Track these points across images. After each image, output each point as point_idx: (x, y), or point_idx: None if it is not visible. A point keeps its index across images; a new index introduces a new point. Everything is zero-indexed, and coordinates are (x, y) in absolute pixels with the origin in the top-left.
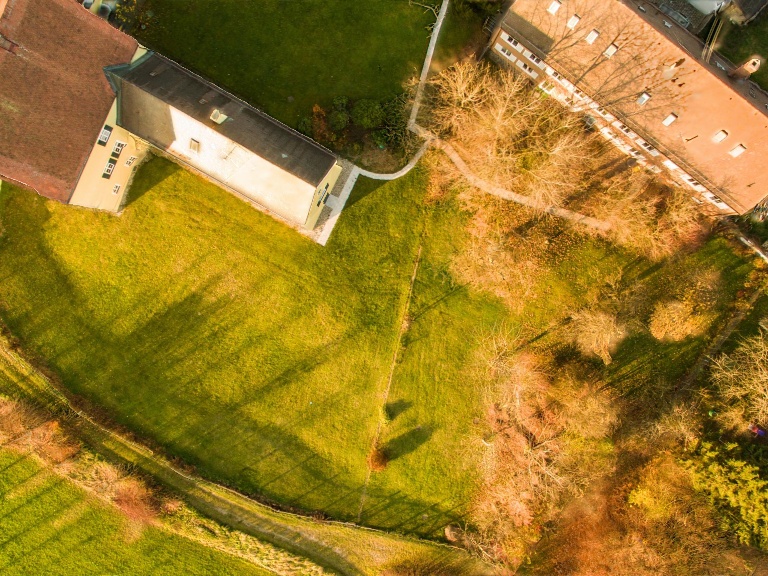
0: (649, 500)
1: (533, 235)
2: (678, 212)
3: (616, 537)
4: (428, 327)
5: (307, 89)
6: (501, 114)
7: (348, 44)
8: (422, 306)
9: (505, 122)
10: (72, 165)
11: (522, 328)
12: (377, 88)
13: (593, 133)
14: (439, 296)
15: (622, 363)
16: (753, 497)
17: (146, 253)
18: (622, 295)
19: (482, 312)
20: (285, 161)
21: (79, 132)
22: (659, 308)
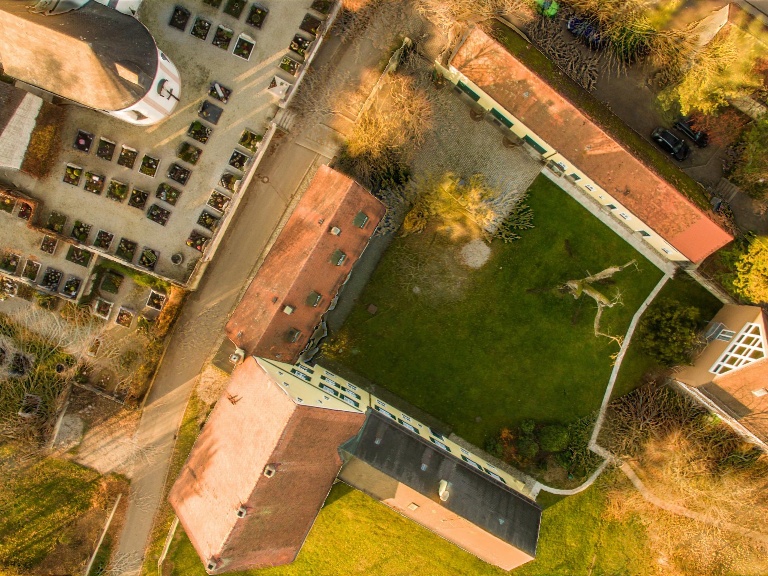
0: None
1: (701, 547)
2: None
3: None
4: None
5: (495, 411)
6: (676, 436)
7: (536, 370)
8: None
9: None
10: (301, 532)
11: None
12: (561, 411)
13: None
14: None
15: None
16: None
17: (329, 553)
18: None
19: None
20: (504, 529)
21: (311, 504)
22: None
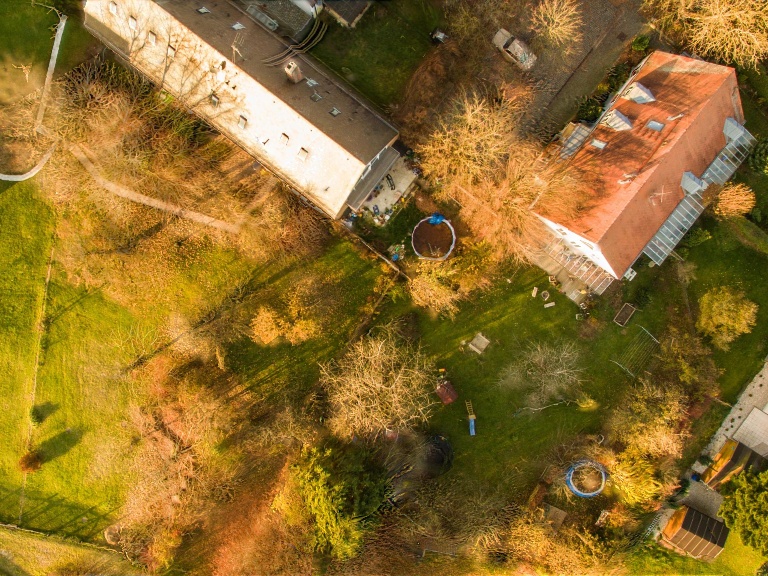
0: (285, 506)
1: (163, 238)
2: (298, 216)
3: (269, 542)
4: (66, 329)
5: None
6: (128, 116)
7: None
8: (59, 308)
9: (131, 124)
10: None
11: (158, 331)
12: (3, 89)
13: (221, 135)
14: (74, 298)
15: (259, 367)
16: (320, 504)
17: None
18: (245, 299)
19: (118, 315)
20: None
21: None
22: (261, 312)
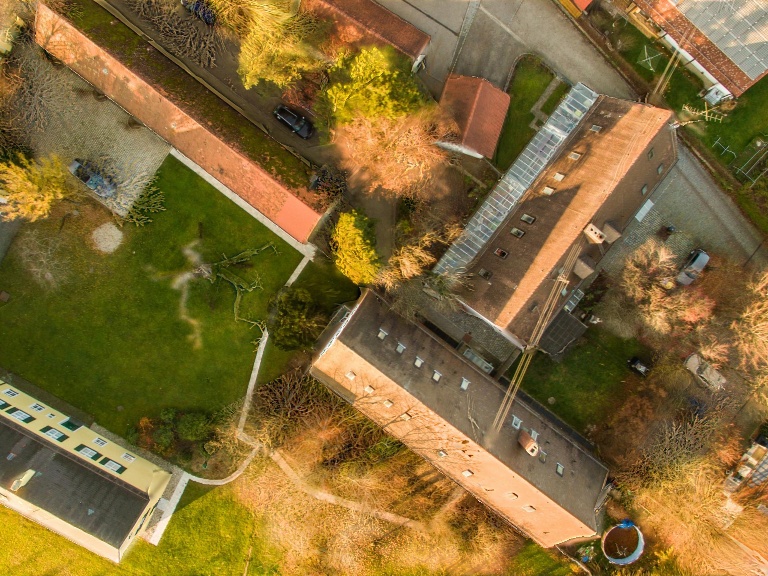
0: None
1: (359, 537)
2: (495, 523)
3: None
4: None
5: (136, 399)
6: (327, 423)
7: (176, 357)
8: None
9: (331, 431)
10: None
11: None
12: (205, 399)
13: None
14: None
15: None
16: None
17: None
18: None
19: None
20: (90, 520)
21: None
22: None
